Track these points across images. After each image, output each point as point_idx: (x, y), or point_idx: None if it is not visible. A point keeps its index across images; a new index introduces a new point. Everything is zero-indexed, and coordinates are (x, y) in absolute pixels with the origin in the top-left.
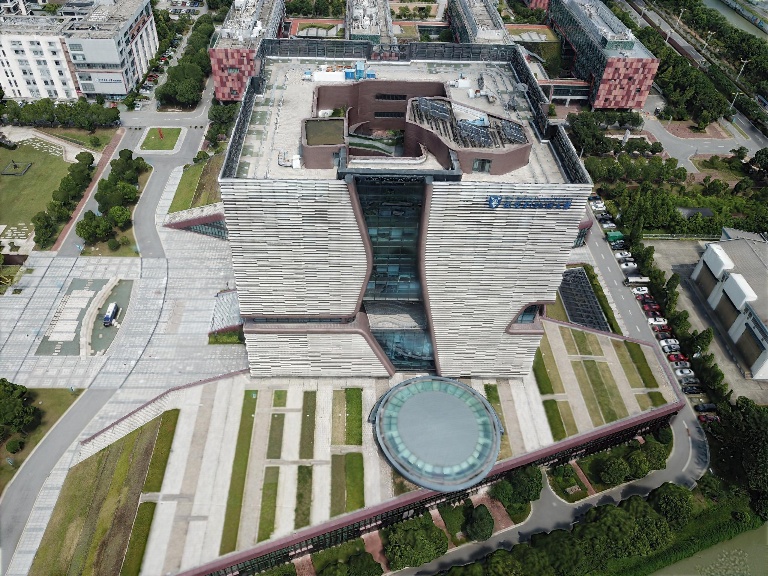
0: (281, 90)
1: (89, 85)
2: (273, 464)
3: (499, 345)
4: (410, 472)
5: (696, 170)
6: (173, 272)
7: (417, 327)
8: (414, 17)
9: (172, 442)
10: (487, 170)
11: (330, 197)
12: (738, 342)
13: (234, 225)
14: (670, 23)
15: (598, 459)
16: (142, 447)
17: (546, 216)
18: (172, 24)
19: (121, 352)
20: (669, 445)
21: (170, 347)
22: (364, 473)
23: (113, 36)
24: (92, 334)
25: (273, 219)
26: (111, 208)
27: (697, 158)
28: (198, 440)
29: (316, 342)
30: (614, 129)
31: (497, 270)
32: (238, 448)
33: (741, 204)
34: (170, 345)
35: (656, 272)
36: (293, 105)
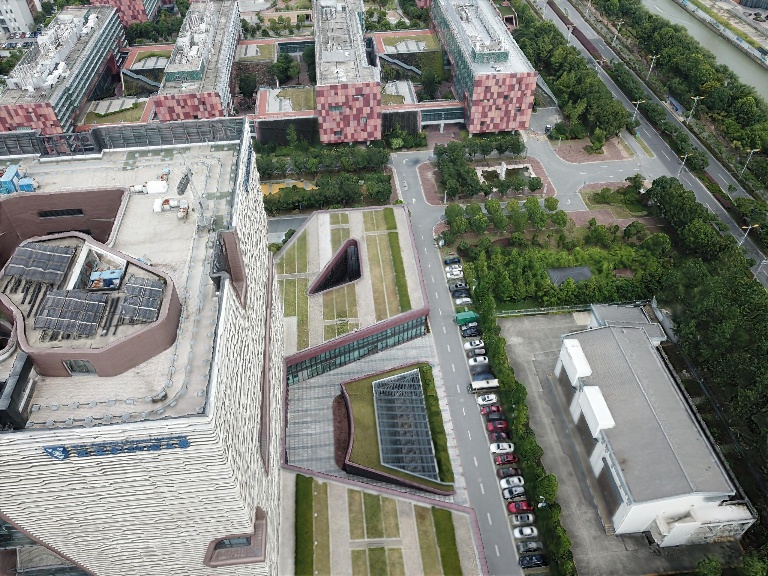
0: None
1: None
2: None
3: None
4: None
5: (584, 207)
6: None
7: None
8: (284, 30)
9: None
10: (93, 370)
11: None
12: (599, 478)
13: None
14: (580, 11)
15: None
16: None
17: (159, 458)
18: None
19: None
20: None
21: None
22: None
23: None
24: None
25: None
26: None
27: (588, 190)
28: None
29: None
30: (494, 158)
31: (135, 515)
32: None
33: (628, 257)
34: None
35: (504, 375)
36: None
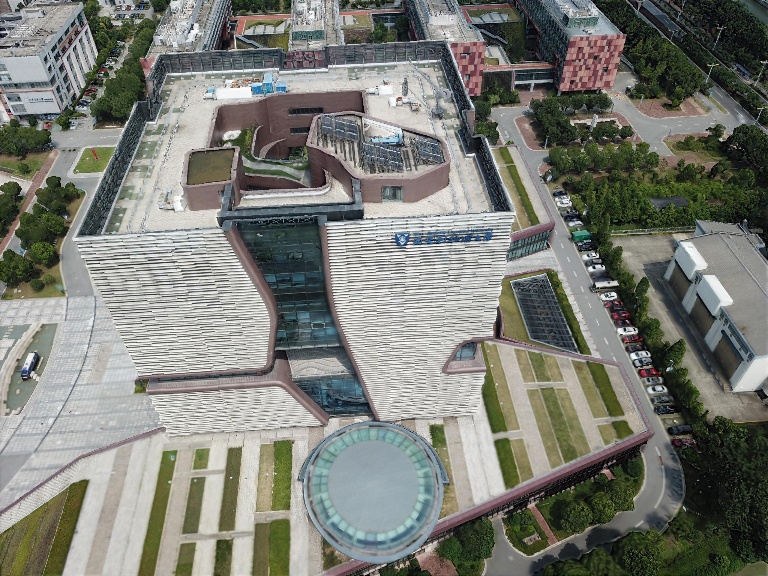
0: (178, 113)
1: (19, 106)
2: (189, 540)
3: (438, 386)
4: (340, 542)
5: (670, 153)
6: (101, 311)
7: (345, 372)
8: (370, 4)
9: (77, 521)
10: (399, 197)
11: (208, 248)
12: (715, 350)
13: (105, 285)
14: None
15: (560, 501)
16: (45, 528)
17: (465, 250)
18: (113, 31)
19: (39, 409)
20: (640, 478)
21: (92, 399)
22: (291, 544)
23: (38, 52)
24: (8, 390)
25: (148, 276)
26: (34, 244)
27: (671, 139)
28: (107, 516)
29: (232, 397)
30: (582, 113)
31: (420, 310)
32: (151, 523)
33: (718, 189)
34: (93, 397)
35: (625, 275)
36: (188, 131)
